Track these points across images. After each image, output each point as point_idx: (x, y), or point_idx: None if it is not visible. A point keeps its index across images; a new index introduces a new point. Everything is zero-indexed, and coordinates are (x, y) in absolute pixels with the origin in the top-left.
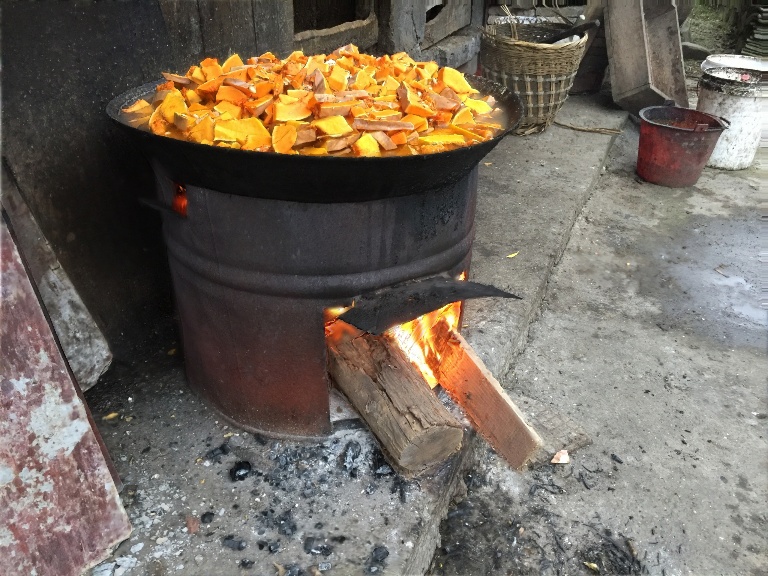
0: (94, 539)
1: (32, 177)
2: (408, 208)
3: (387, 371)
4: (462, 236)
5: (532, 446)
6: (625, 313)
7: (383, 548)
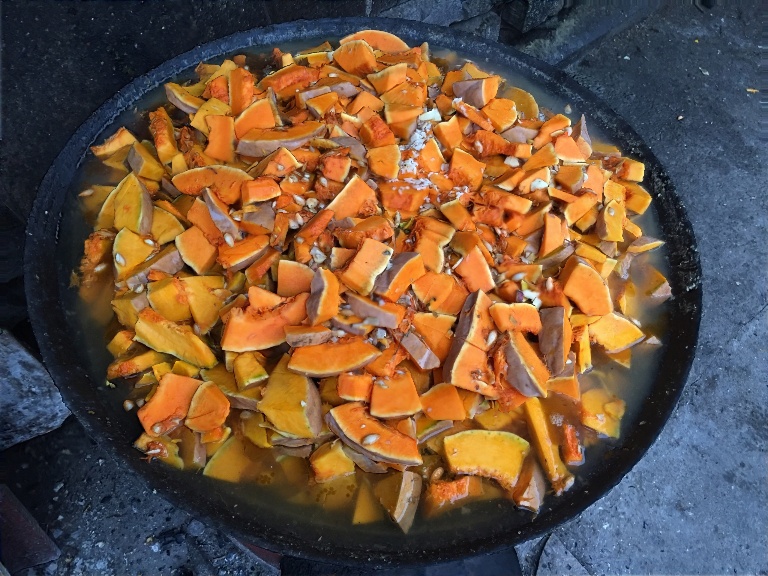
0: None
1: (5, 173)
2: None
3: None
4: None
5: None
6: None
7: None
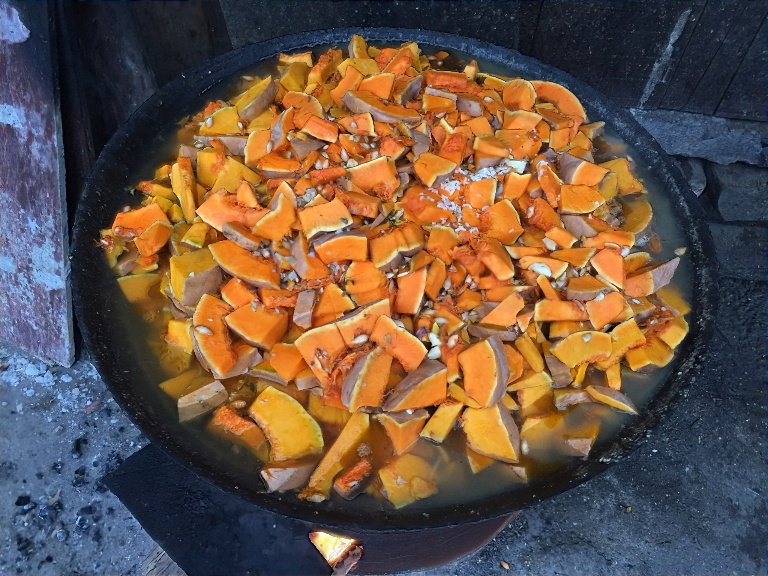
0: (47, 348)
1: None
2: None
3: None
4: None
5: None
6: None
7: None
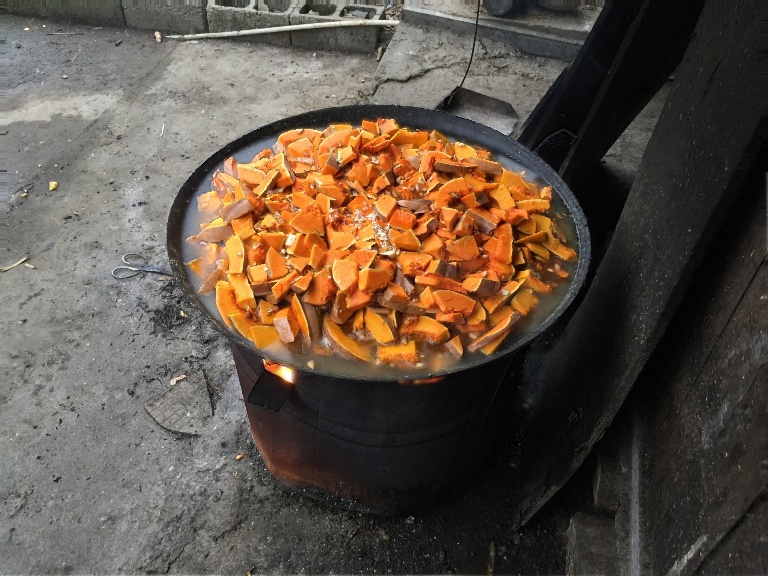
0: None
1: None
2: None
3: None
4: None
5: None
6: None
7: None
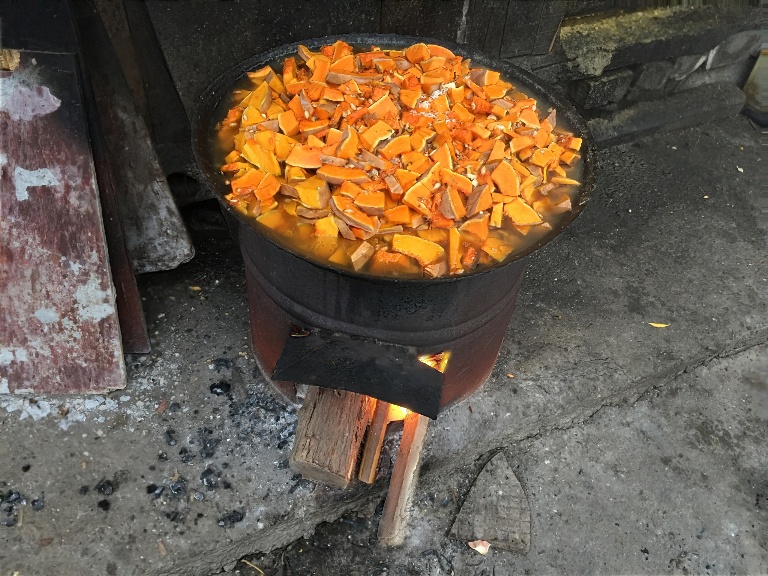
0: (99, 379)
1: (193, 93)
2: (363, 289)
3: (328, 394)
4: (444, 326)
5: (386, 532)
6: (738, 458)
7: (239, 515)
